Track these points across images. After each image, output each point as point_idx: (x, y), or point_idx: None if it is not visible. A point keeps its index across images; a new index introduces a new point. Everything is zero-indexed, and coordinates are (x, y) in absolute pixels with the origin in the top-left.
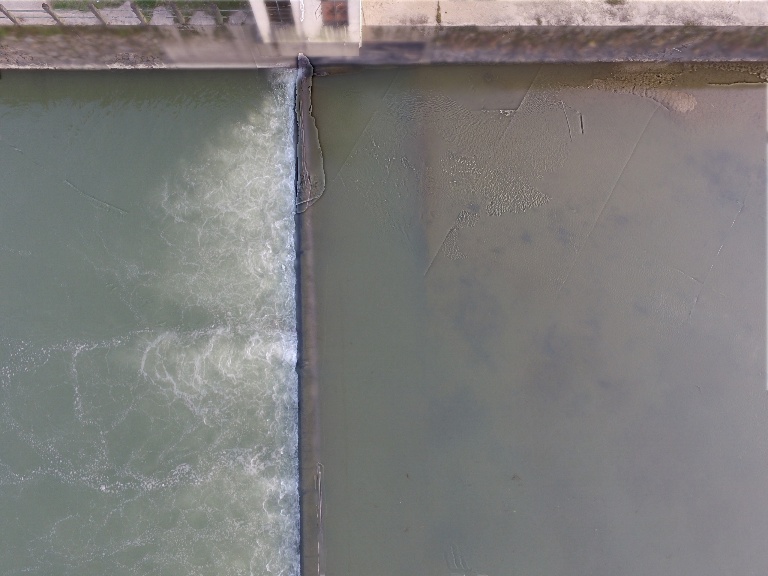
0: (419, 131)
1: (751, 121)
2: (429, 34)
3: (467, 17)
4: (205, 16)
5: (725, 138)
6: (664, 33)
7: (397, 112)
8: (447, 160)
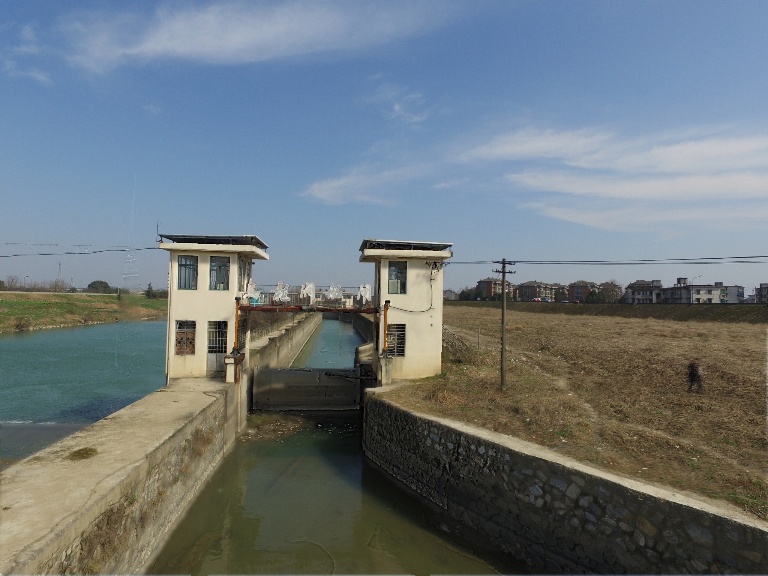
0: None
1: None
2: None
3: None
4: None
5: None
6: None
7: None
8: None
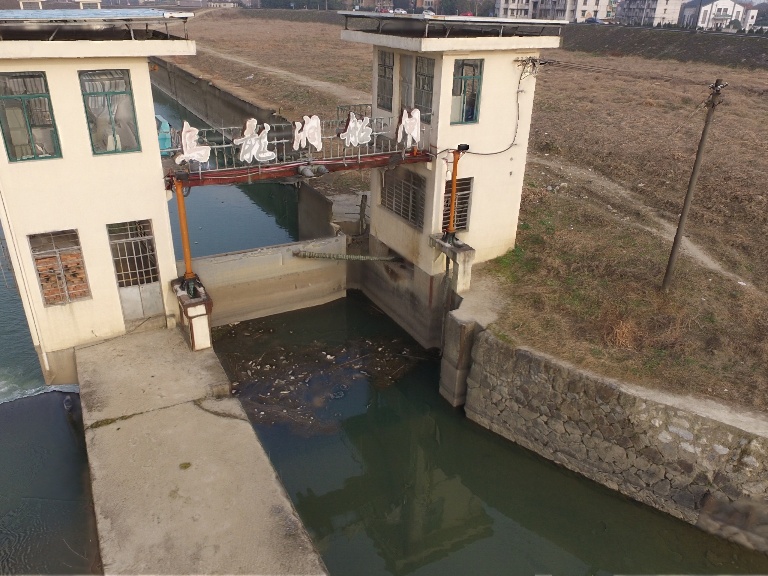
0: None
1: None
2: None
3: (113, 462)
4: None
5: None
6: None
7: None
8: None
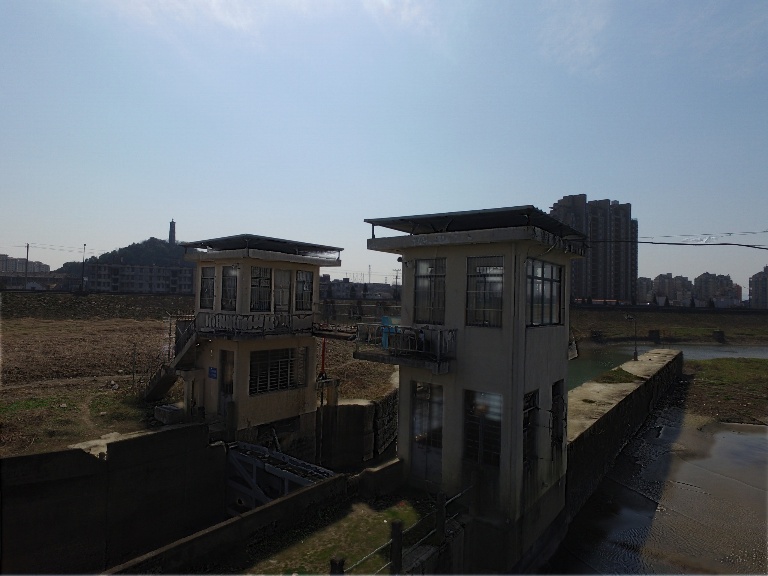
0: (677, 567)
1: (699, 438)
2: (568, 460)
3: (569, 432)
4: (411, 550)
5: (715, 449)
6: (624, 407)
7: (633, 573)
8: (737, 568)
